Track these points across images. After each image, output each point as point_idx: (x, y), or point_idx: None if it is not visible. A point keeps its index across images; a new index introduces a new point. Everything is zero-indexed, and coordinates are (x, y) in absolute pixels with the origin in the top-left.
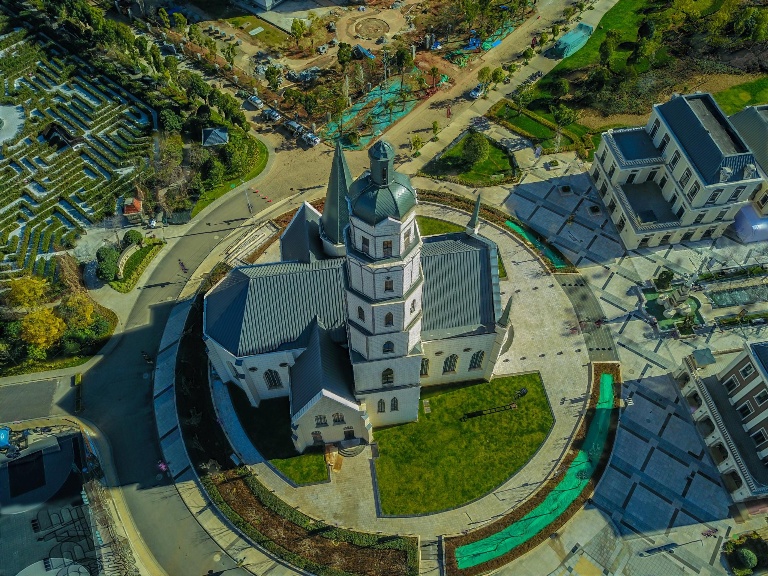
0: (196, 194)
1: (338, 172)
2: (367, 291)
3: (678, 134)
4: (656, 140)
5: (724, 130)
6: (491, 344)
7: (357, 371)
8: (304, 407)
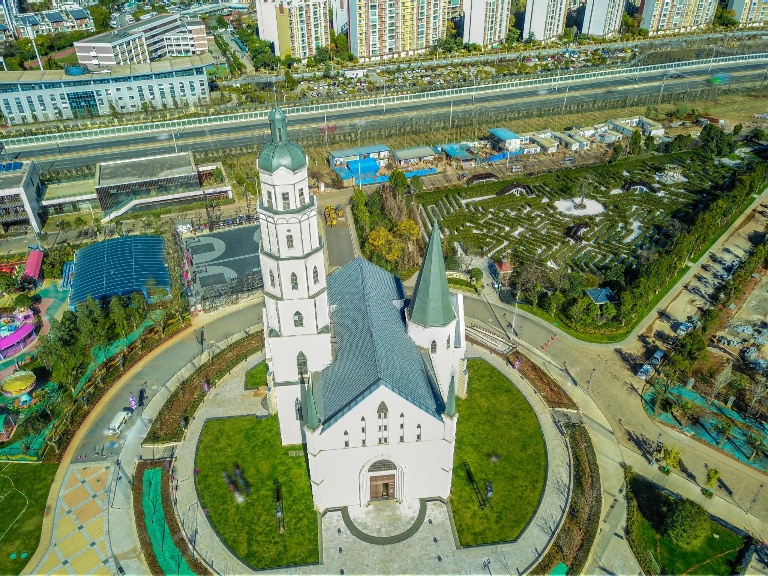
0: None
1: (427, 247)
2: None
3: None
4: None
5: None
6: None
7: None
8: None
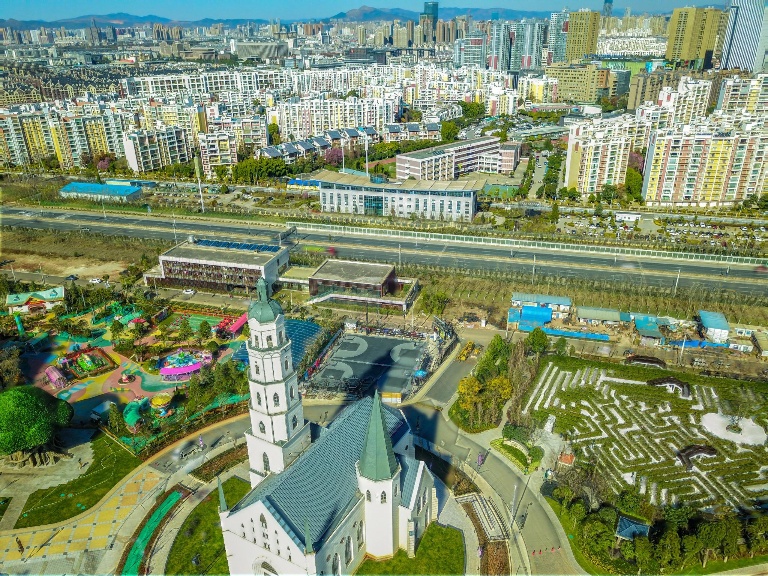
0: None
1: None
2: None
3: None
4: None
5: None
6: None
7: None
8: None
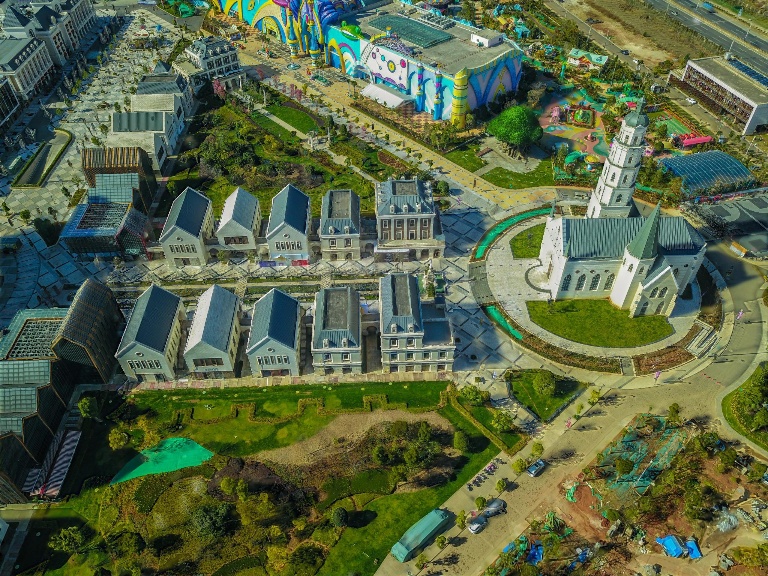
0: None
1: None
2: None
3: (418, 308)
4: None
5: (396, 293)
6: None
7: None
8: None
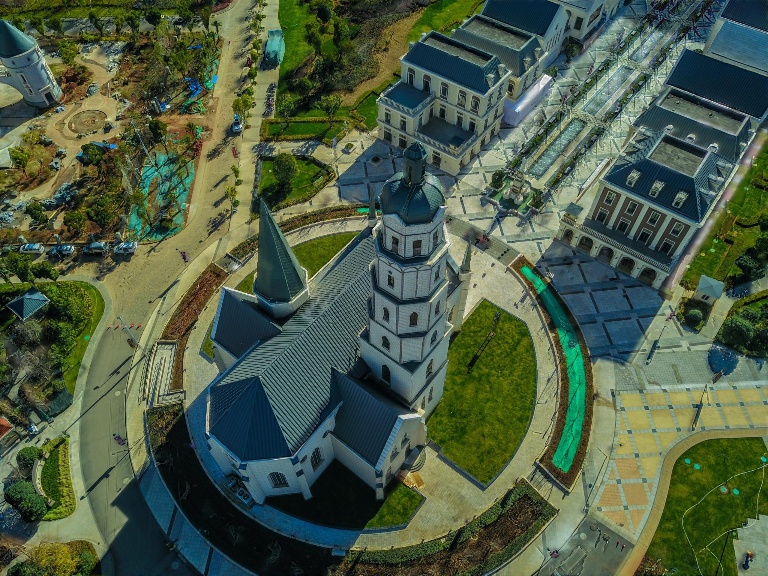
0: (56, 370)
1: (271, 230)
2: (421, 292)
3: (435, 70)
4: (417, 84)
5: (464, 51)
6: (459, 295)
7: (413, 380)
8: (385, 447)
